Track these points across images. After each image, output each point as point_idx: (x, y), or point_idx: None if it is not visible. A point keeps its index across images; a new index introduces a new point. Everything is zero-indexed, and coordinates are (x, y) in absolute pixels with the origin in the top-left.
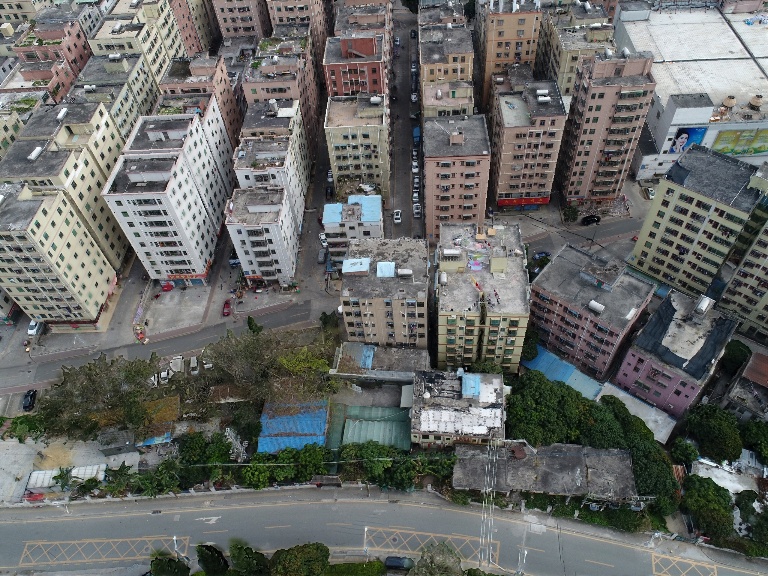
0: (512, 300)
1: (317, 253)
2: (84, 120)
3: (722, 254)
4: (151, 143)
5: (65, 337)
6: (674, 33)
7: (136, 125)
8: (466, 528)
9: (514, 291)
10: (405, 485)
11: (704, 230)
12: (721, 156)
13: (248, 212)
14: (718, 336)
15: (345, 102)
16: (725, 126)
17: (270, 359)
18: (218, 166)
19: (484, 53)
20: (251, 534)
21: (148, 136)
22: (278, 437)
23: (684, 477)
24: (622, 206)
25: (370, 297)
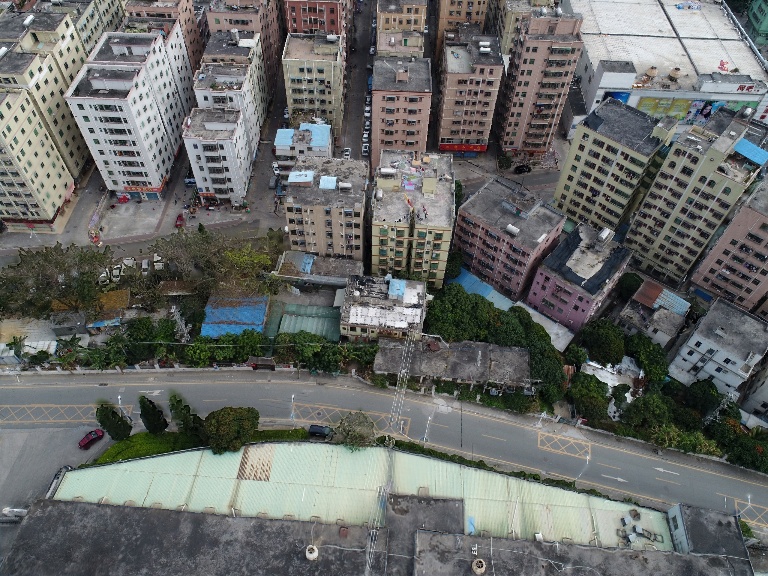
0: (438, 216)
1: (269, 179)
2: (50, 28)
3: (626, 195)
4: (115, 57)
5: (21, 236)
6: (613, 10)
7: (101, 39)
8: (383, 407)
9: (441, 209)
10: (331, 367)
11: (612, 173)
12: (632, 110)
13: (205, 129)
14: (614, 262)
15: (303, 39)
16: (646, 93)
17: (217, 258)
18: (179, 90)
19: (438, 11)
20: (190, 405)
21: (112, 50)
22: (220, 324)
23: (573, 374)
24: (552, 160)
25: (312, 204)
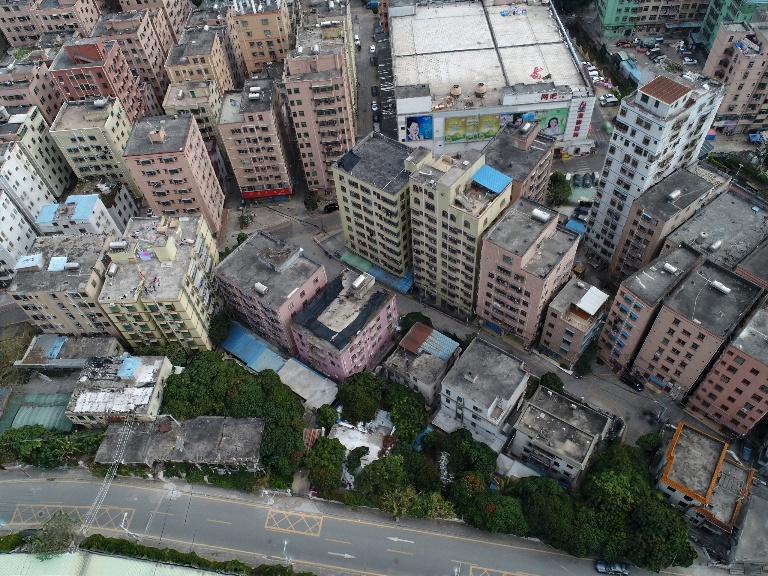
0: (170, 286)
1: None
2: None
3: (394, 233)
4: None
5: None
6: (434, 27)
7: None
8: (109, 499)
9: (175, 278)
10: (51, 463)
11: (375, 212)
12: (394, 143)
13: None
14: (371, 309)
15: (80, 106)
16: (448, 114)
17: None
18: None
19: None
20: None
21: None
22: None
23: (316, 439)
24: None
25: (34, 290)
